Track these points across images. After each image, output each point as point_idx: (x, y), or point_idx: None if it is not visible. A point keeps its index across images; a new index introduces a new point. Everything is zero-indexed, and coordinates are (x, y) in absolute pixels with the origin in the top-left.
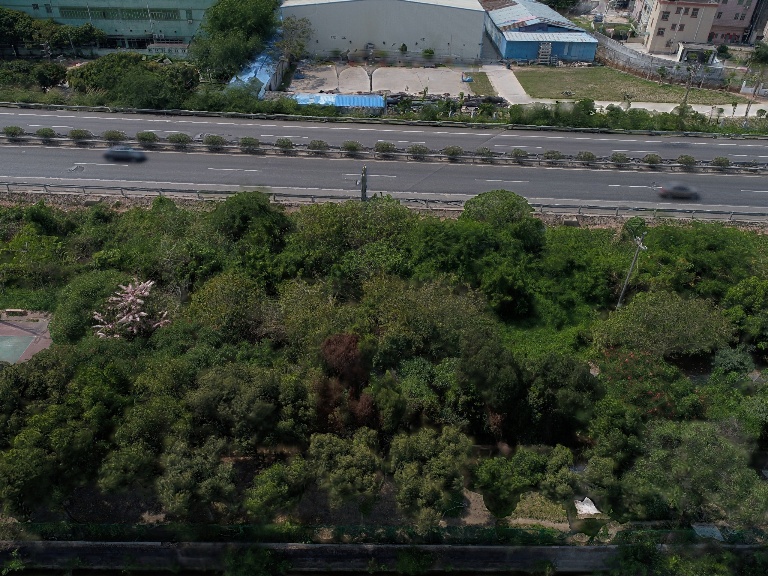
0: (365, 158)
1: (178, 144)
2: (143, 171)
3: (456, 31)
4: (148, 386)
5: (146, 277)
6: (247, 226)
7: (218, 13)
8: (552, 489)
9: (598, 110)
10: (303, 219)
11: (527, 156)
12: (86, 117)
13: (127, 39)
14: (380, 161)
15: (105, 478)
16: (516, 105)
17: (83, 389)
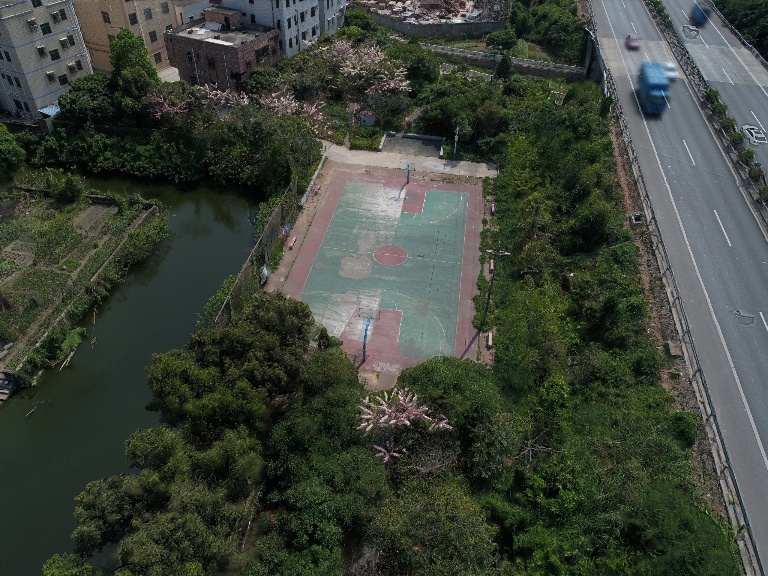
0: None
1: None
2: None
3: None
4: None
5: (535, 437)
6: (646, 552)
7: None
8: None
9: None
10: None
11: None
12: None
13: None
14: None
15: None
16: None
17: None
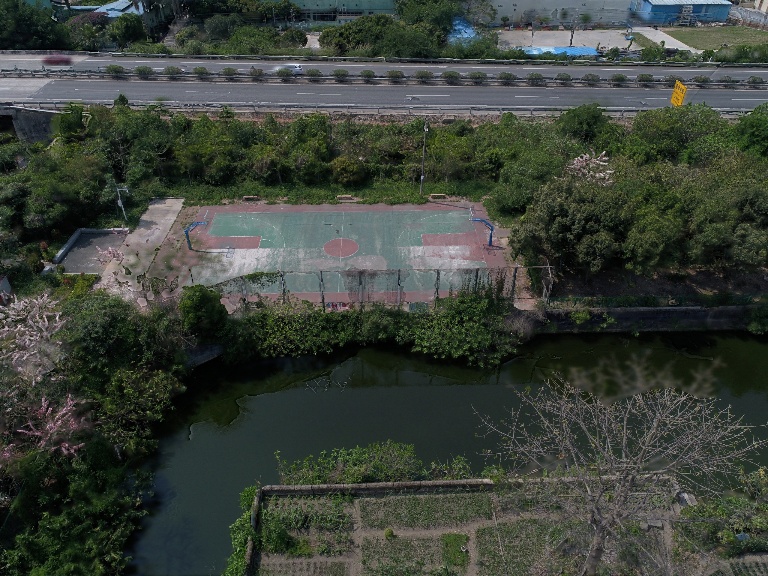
0: (630, 87)
1: (478, 80)
2: (467, 99)
3: None
4: (685, 200)
5: None
6: (592, 130)
7: None
8: None
9: None
10: (644, 121)
11: (761, 82)
12: (372, 65)
13: (312, 13)
14: (644, 89)
15: (695, 250)
16: (709, 50)
17: (650, 200)
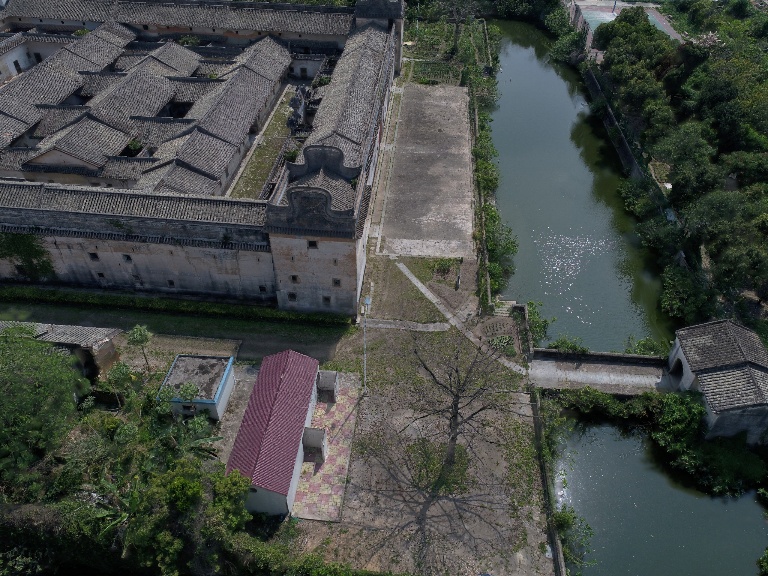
0: None
1: None
2: None
3: None
4: None
5: None
6: None
7: None
8: None
9: None
10: None
11: None
12: None
13: None
14: None
15: (610, 47)
16: None
17: None
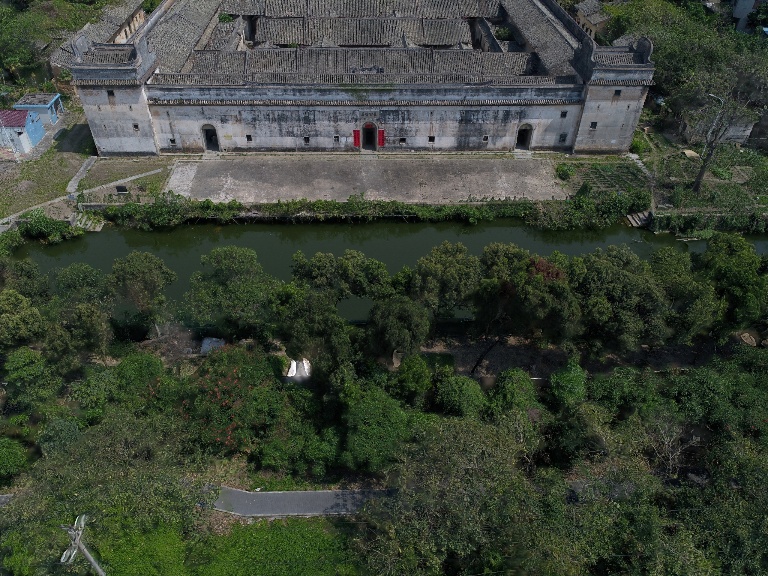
0: None
1: None
2: None
3: None
4: None
5: None
6: None
7: None
8: None
9: None
10: None
11: None
12: None
13: None
14: None
15: None
16: None
17: None
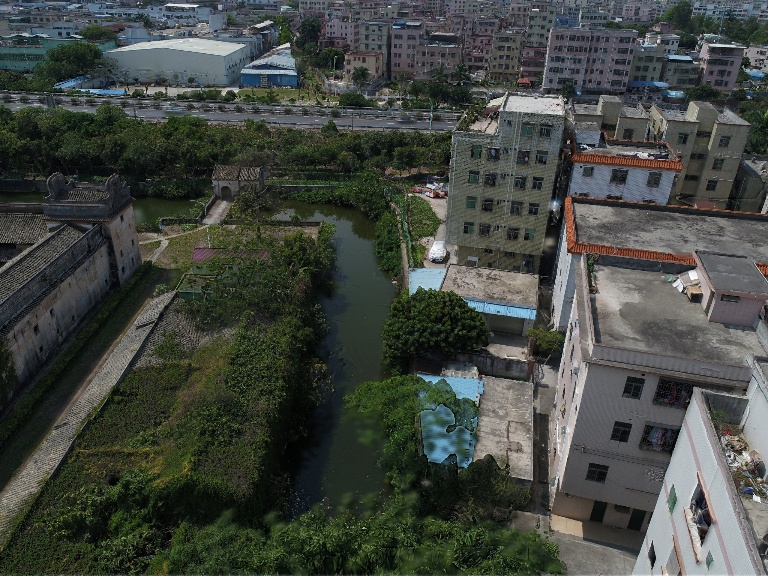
0: None
1: None
2: None
3: (209, 67)
4: None
5: None
6: None
7: (54, 52)
8: (18, 146)
9: (238, 97)
10: None
11: None
12: None
13: None
14: None
15: None
16: None
17: None
